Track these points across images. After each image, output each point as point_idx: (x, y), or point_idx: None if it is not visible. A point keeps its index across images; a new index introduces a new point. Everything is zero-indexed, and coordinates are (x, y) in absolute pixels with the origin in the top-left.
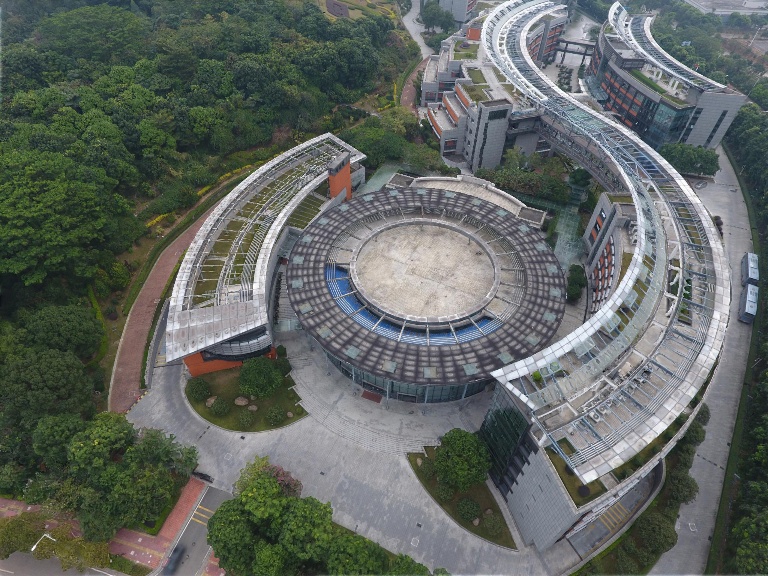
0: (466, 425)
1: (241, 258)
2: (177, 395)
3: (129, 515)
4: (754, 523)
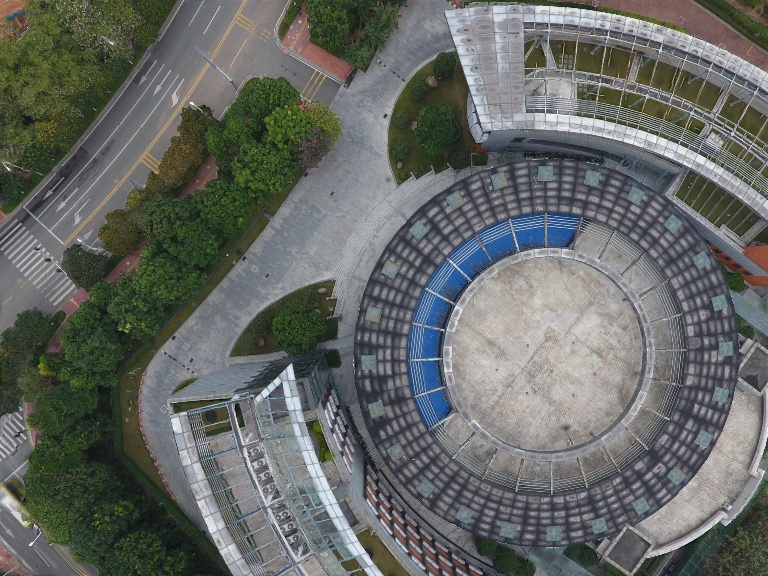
0: (350, 348)
1: (628, 103)
2: (450, 44)
3: (309, 6)
4: (169, 571)
